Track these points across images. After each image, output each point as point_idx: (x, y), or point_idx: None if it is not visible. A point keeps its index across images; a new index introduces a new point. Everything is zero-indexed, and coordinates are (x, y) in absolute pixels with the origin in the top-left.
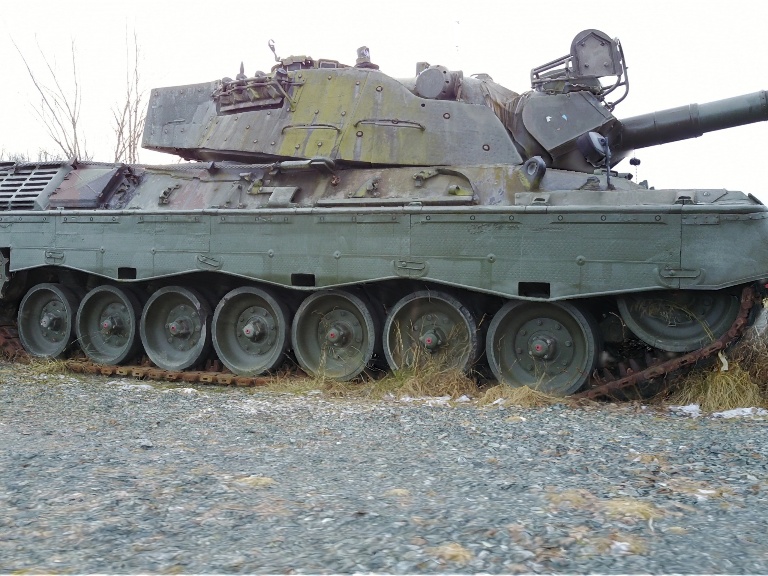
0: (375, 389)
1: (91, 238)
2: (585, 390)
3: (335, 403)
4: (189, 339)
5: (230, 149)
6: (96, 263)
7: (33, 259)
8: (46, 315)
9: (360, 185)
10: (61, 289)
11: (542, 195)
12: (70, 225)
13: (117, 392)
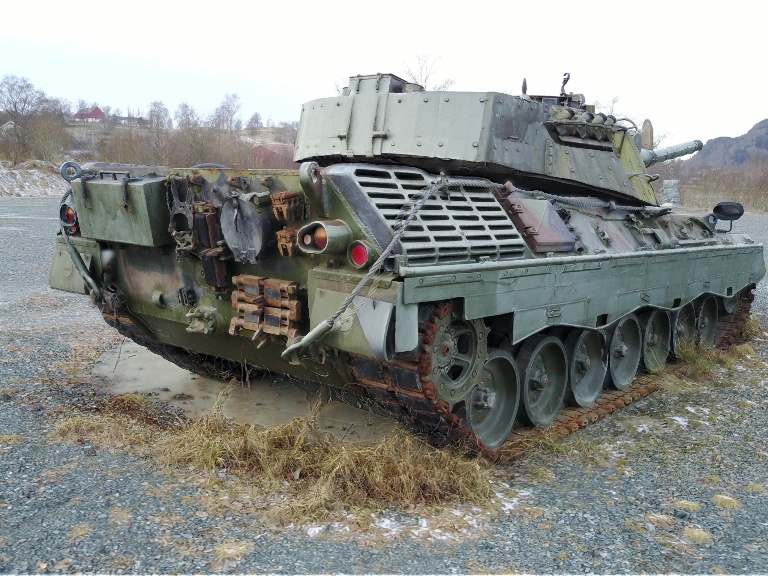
0: (712, 368)
1: (582, 288)
2: (715, 340)
3: (766, 380)
4: None
5: (613, 189)
6: (584, 315)
7: None
8: (491, 392)
9: (673, 228)
10: None
11: (723, 237)
12: (568, 275)
13: (766, 420)
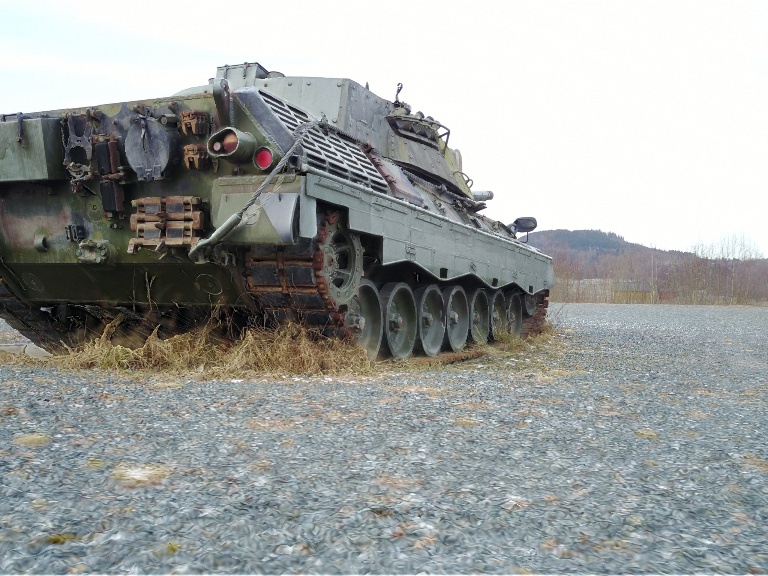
0: None
1: None
2: (521, 336)
3: None
4: (424, 330)
5: None
6: None
7: (398, 253)
8: None
9: (487, 224)
10: (375, 286)
11: None
12: None
13: None
